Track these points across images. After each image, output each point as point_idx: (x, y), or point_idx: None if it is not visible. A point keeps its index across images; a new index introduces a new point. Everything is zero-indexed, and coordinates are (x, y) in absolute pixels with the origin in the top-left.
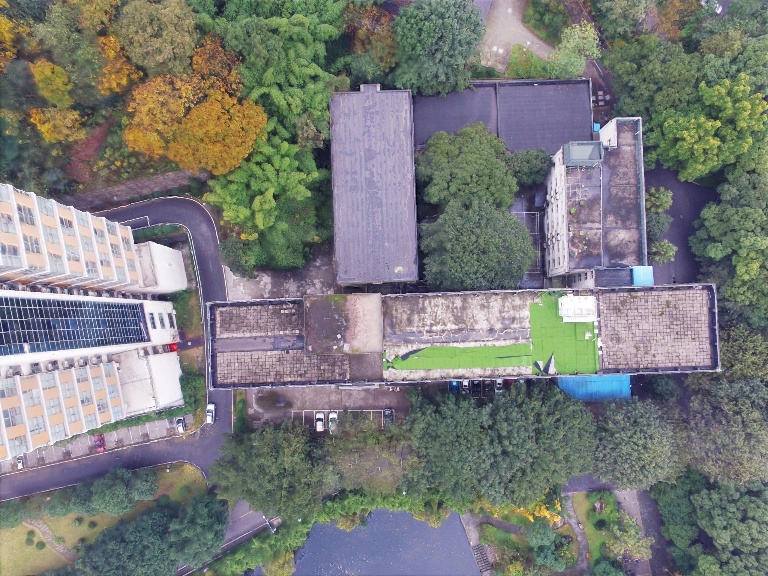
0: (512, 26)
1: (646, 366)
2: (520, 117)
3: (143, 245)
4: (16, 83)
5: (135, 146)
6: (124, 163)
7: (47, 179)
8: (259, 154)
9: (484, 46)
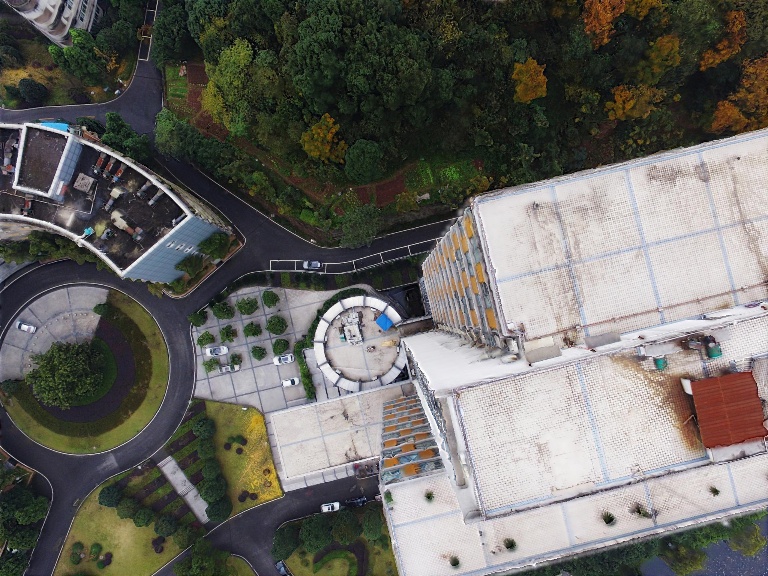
0: None
1: None
2: None
3: None
4: (624, 59)
5: (727, 123)
6: (647, 142)
7: (565, 158)
8: None
9: None
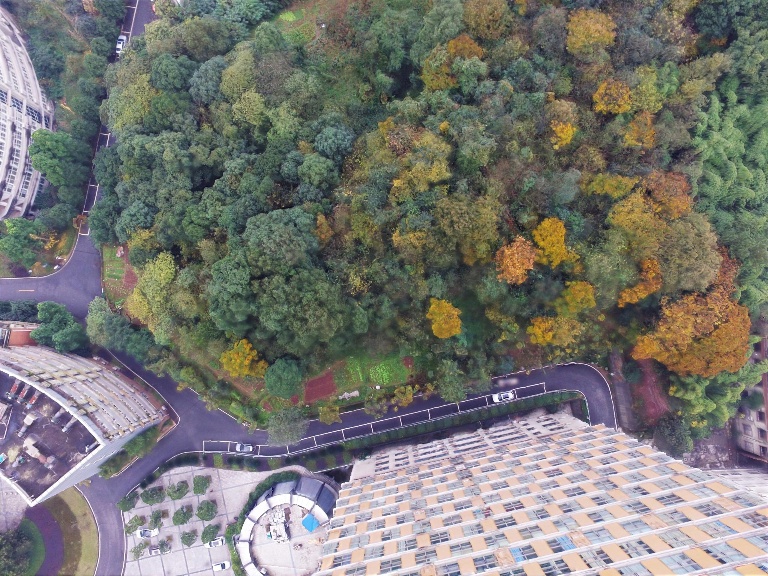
0: None
1: None
2: None
3: None
4: (539, 299)
5: None
6: (575, 351)
7: (493, 365)
8: None
9: None
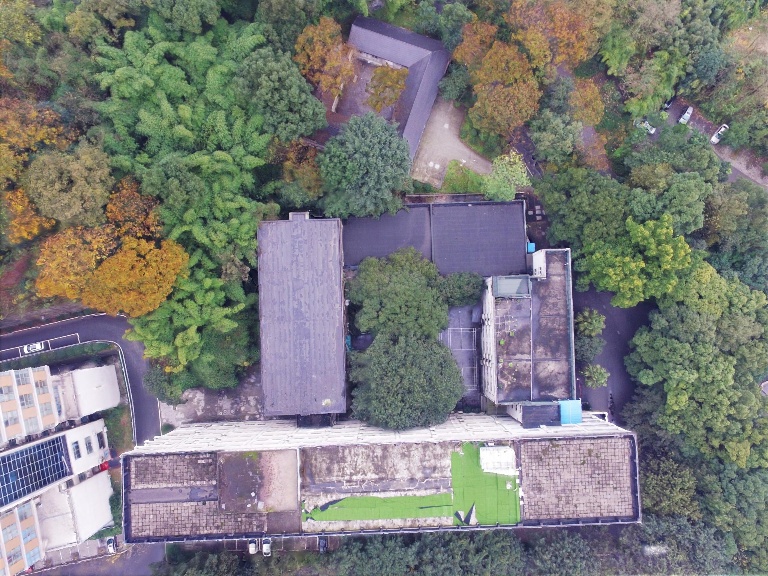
0: (449, 141)
1: (567, 516)
2: (454, 238)
3: (66, 376)
4: None
5: (47, 294)
6: None
7: None
8: (181, 291)
9: (420, 162)
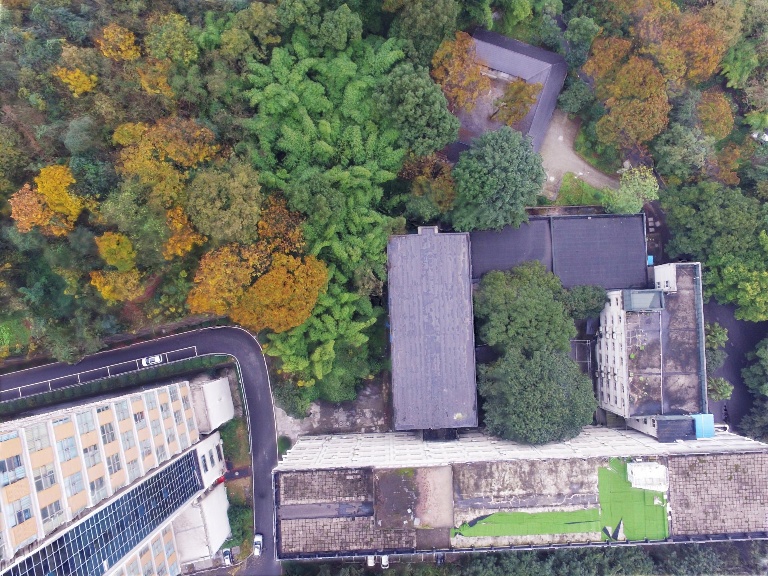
0: (563, 154)
1: (715, 532)
2: (574, 251)
3: (197, 390)
4: (78, 251)
5: (198, 311)
6: (179, 309)
7: (99, 324)
8: (319, 306)
9: None
